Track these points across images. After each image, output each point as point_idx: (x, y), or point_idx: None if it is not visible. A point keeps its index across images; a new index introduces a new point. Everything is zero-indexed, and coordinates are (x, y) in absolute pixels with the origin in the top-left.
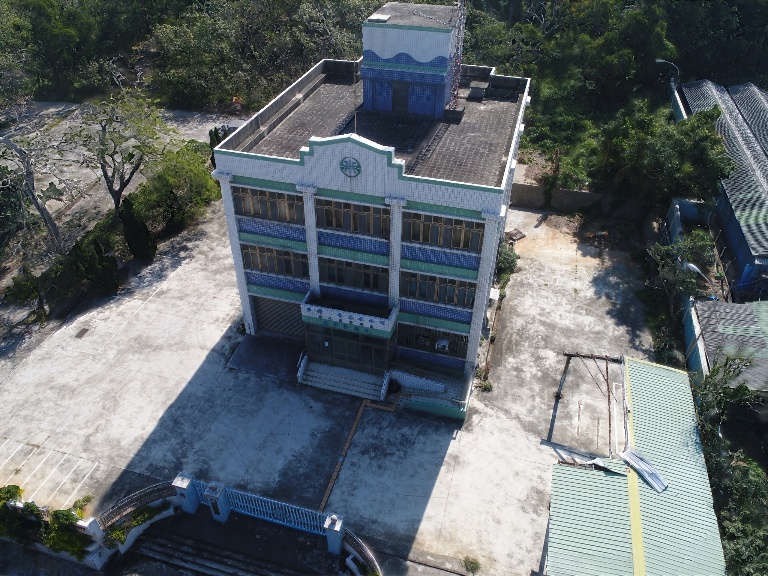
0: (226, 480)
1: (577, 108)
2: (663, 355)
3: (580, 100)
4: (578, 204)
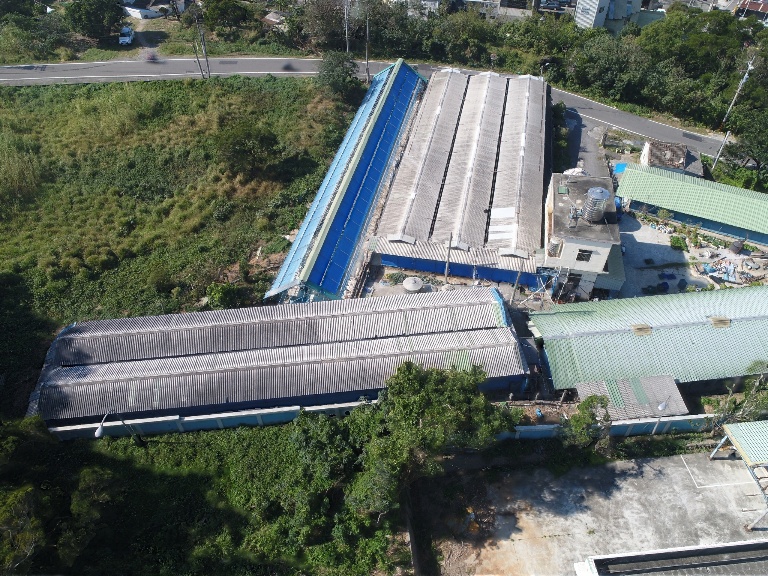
0: None
1: (143, 574)
2: (639, 452)
3: (101, 574)
4: (415, 548)
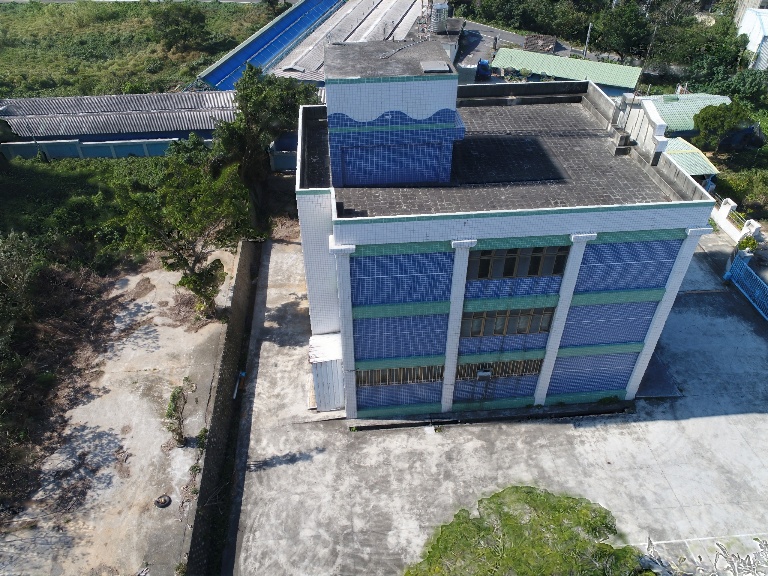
0: (763, 343)
1: (26, 206)
2: None
3: None
4: (254, 218)
